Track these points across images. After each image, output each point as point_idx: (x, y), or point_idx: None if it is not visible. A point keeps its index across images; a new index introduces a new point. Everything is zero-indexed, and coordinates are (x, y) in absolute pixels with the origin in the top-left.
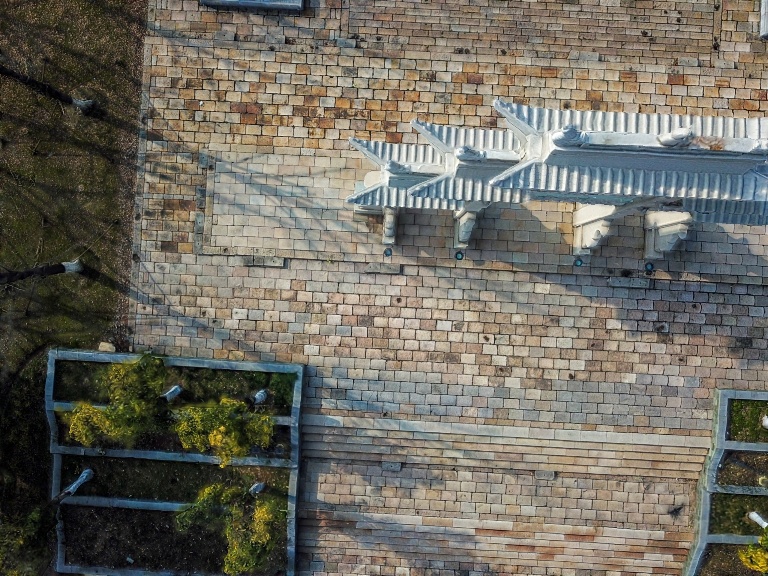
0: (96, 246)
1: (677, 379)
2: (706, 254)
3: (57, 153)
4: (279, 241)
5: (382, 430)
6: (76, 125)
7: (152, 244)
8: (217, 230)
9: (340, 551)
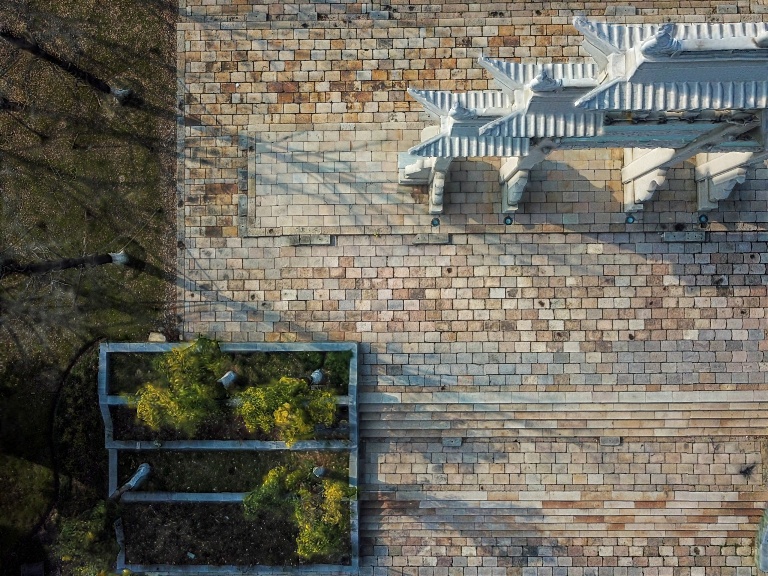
0: (140, 236)
1: (741, 332)
2: (761, 202)
3: (96, 145)
4: (324, 218)
5: (441, 404)
6: (113, 116)
7: (196, 230)
8: (261, 211)
9: (404, 533)
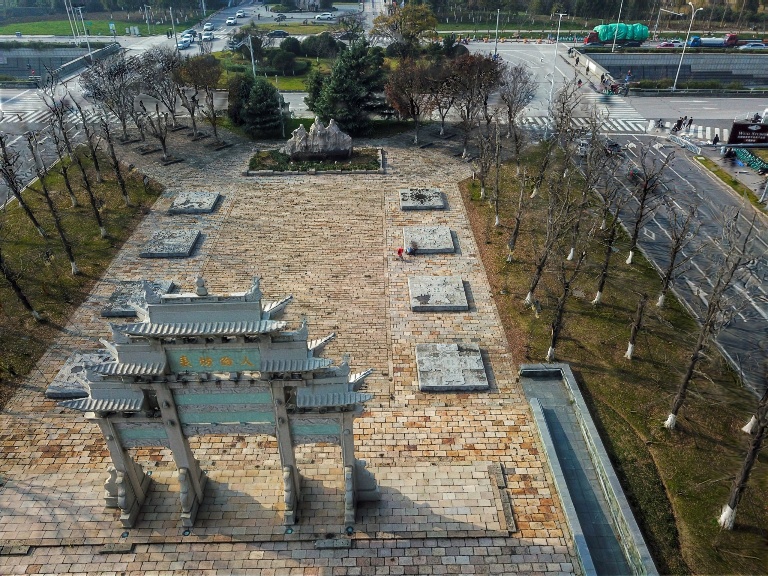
0: None
1: None
2: (397, 517)
3: None
4: (32, 533)
5: None
6: None
7: None
8: None
9: None
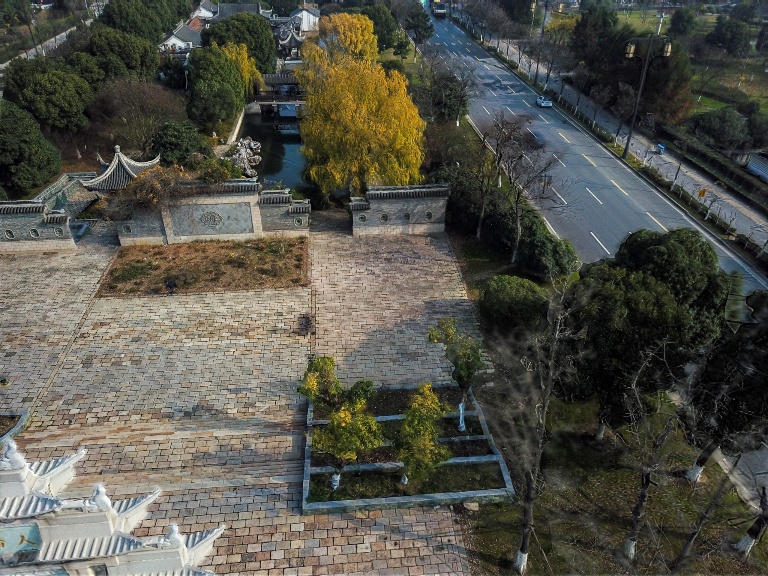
0: None
1: None
2: None
3: None
4: None
5: (238, 479)
6: None
7: None
8: None
9: (277, 416)
